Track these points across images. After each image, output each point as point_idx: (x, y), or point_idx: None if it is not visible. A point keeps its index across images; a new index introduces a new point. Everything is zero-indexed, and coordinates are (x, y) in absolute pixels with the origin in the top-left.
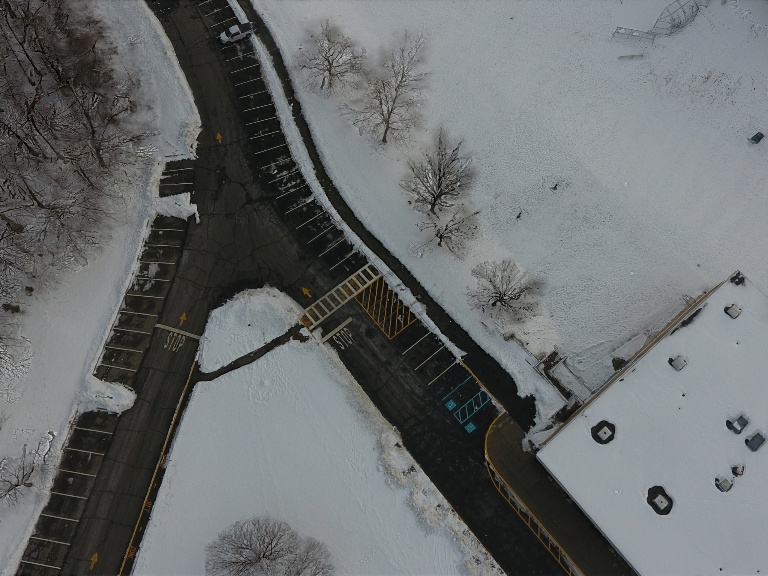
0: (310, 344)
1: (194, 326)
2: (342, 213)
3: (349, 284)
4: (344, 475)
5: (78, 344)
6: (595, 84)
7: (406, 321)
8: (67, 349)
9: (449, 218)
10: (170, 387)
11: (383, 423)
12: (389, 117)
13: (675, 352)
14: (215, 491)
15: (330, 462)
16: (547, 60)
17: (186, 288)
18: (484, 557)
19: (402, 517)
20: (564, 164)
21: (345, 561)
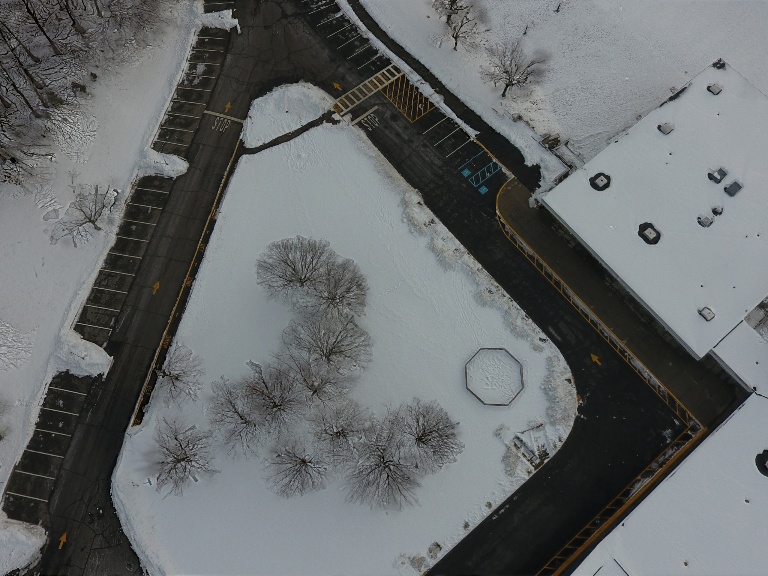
0: (341, 125)
1: (238, 112)
2: (368, 25)
3: (375, 80)
4: (373, 225)
5: (137, 123)
6: None
7: (426, 108)
8: (127, 126)
9: None
10: (218, 159)
11: (407, 186)
12: None
13: (663, 120)
14: (260, 237)
15: (360, 215)
16: None
17: (230, 83)
18: (496, 289)
19: (424, 257)
20: None
21: (375, 290)
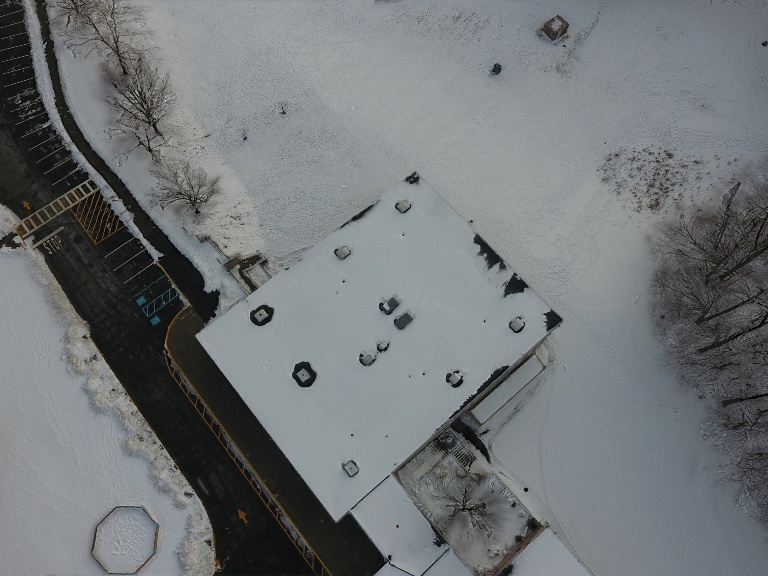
0: (19, 249)
1: None
2: (73, 136)
3: (67, 197)
4: (28, 364)
5: None
6: (349, 25)
7: (114, 228)
8: None
9: (175, 139)
10: None
11: (74, 317)
12: (117, 46)
13: (341, 243)
14: None
15: (18, 353)
16: (306, 4)
17: None
18: (148, 435)
19: (76, 400)
20: (296, 91)
21: (15, 440)
